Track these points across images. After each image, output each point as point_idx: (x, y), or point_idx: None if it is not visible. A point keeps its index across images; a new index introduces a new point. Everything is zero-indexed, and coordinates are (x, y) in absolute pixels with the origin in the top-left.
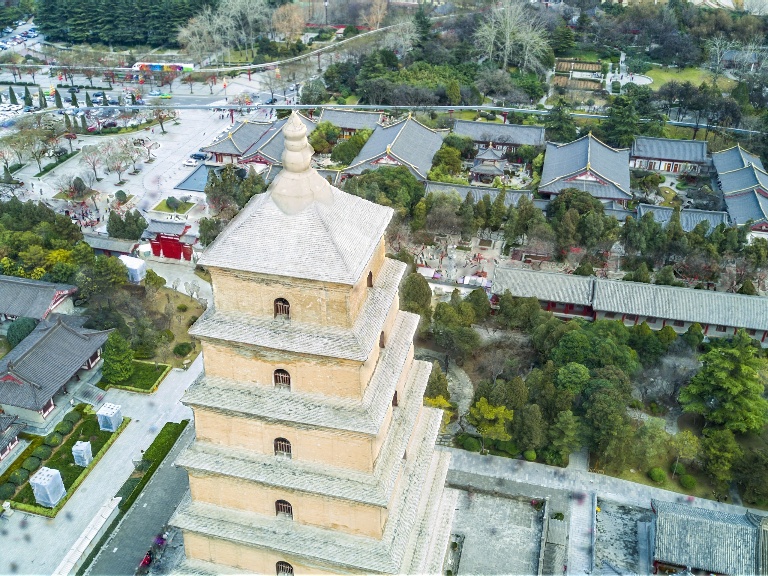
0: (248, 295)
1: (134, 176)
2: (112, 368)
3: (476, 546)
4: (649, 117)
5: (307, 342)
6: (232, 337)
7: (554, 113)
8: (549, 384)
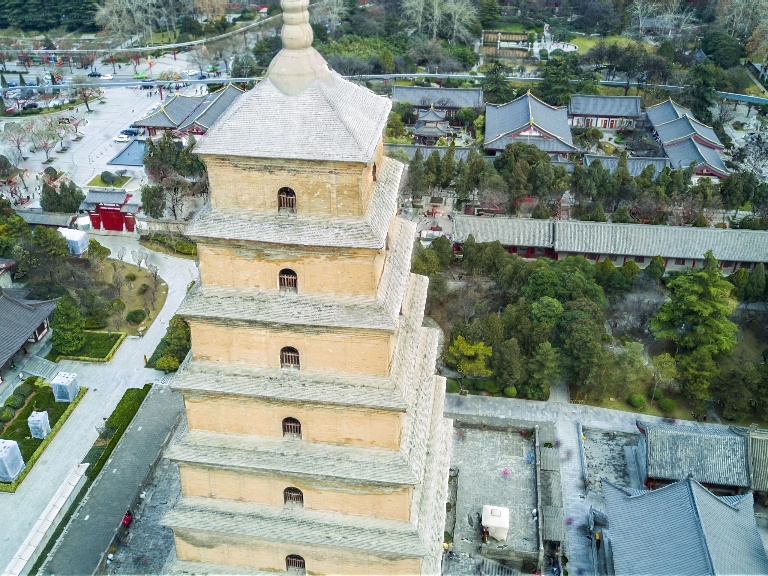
0: (249, 187)
1: (62, 154)
2: (62, 338)
3: (471, 478)
4: (583, 76)
5: (316, 234)
6: (233, 235)
7: (490, 76)
8: (525, 318)
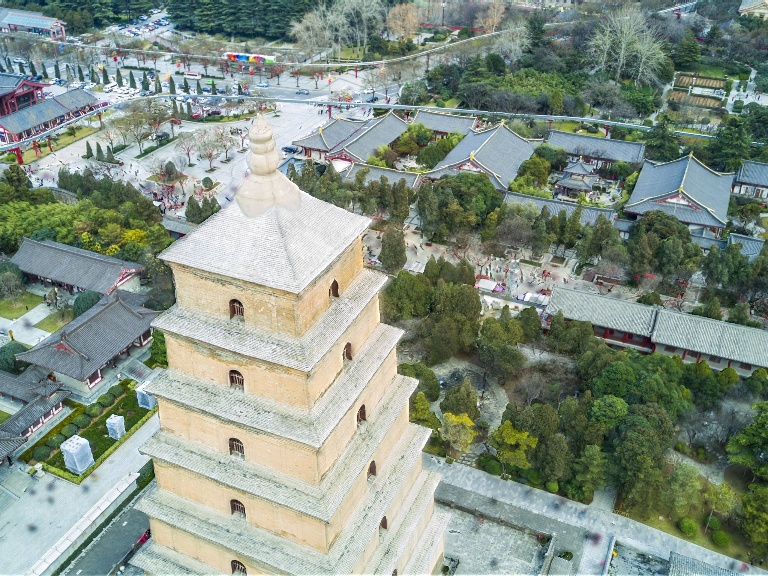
0: (206, 293)
1: (225, 164)
2: (160, 348)
3: (469, 573)
4: (763, 141)
5: (257, 346)
6: (189, 333)
7: (657, 130)
8: (580, 415)
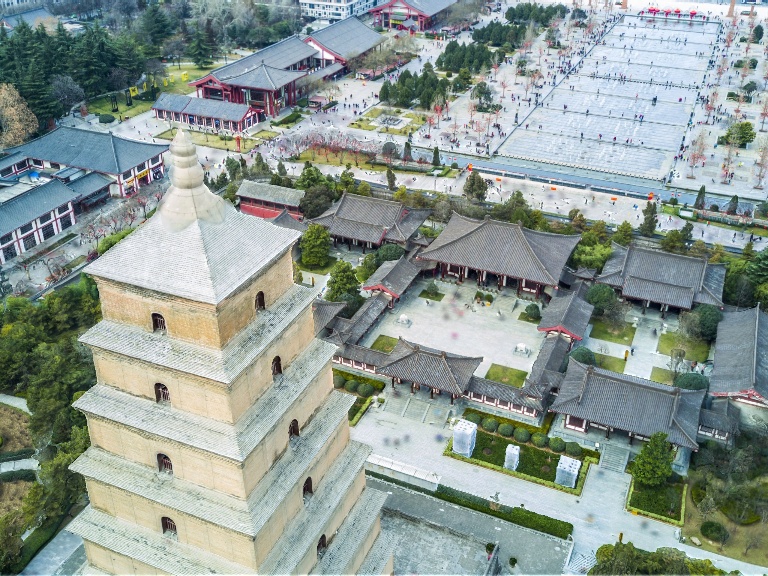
0: None
1: None
2: None
3: None
4: None
5: None
6: None
7: None
8: None
